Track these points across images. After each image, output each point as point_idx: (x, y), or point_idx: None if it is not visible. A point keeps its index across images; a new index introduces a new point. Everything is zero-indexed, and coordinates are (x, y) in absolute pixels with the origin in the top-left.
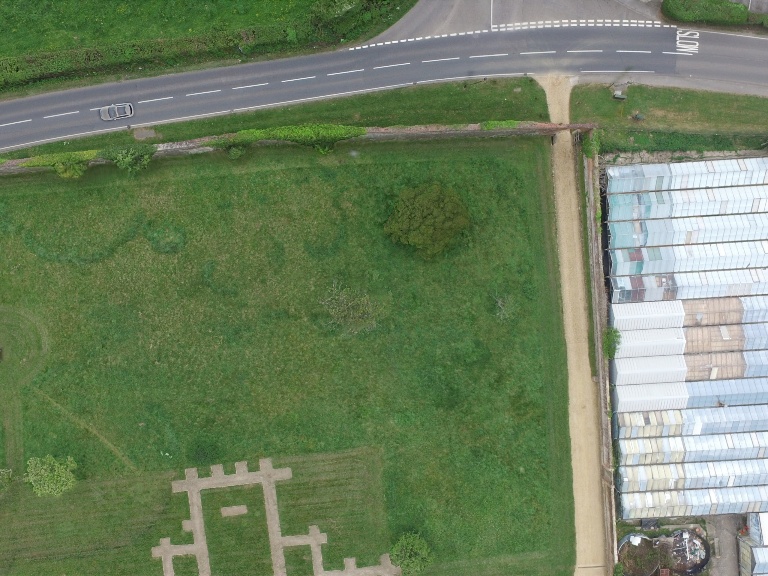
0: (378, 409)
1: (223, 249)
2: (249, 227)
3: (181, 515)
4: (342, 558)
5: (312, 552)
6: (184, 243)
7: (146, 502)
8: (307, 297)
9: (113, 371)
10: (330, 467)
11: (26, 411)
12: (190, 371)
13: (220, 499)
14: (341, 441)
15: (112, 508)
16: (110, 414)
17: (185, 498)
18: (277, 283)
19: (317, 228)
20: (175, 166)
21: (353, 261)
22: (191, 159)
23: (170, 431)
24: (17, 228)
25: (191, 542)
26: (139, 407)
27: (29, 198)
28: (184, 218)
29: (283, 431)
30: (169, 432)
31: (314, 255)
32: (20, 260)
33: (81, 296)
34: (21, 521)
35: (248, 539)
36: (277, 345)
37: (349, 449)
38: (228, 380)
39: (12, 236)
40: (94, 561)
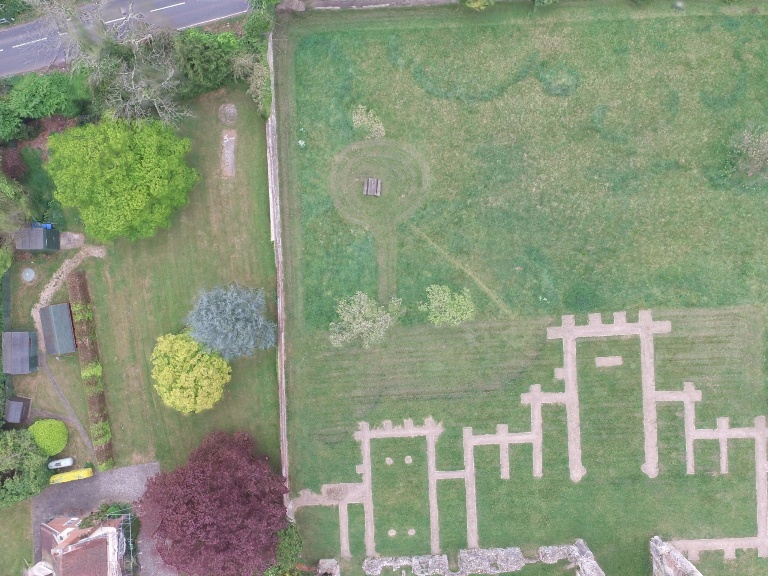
0: (764, 267)
1: (615, 95)
2: (644, 74)
3: (554, 362)
4: (715, 417)
5: (685, 409)
6: (576, 86)
7: (519, 347)
8: (699, 148)
9: (493, 212)
10: (710, 323)
11: (401, 248)
12: (572, 217)
13: (596, 348)
14: (724, 297)
15: (484, 351)
16: (487, 256)
17: (560, 345)
18: (668, 132)
19: (715, 78)
20: (572, 7)
21: (750, 114)
22: (590, 1)
23: (547, 277)
24: (407, 61)
25: (562, 390)
26: (517, 251)
27: (421, 32)
28: (578, 61)
29: (665, 283)
30: (546, 278)
31: (710, 106)
32: (407, 94)
33: (466, 134)
34: (391, 358)
35: (621, 391)
36: (664, 196)
37: (731, 306)
38: (610, 229)
39: (401, 69)
40: (461, 403)
